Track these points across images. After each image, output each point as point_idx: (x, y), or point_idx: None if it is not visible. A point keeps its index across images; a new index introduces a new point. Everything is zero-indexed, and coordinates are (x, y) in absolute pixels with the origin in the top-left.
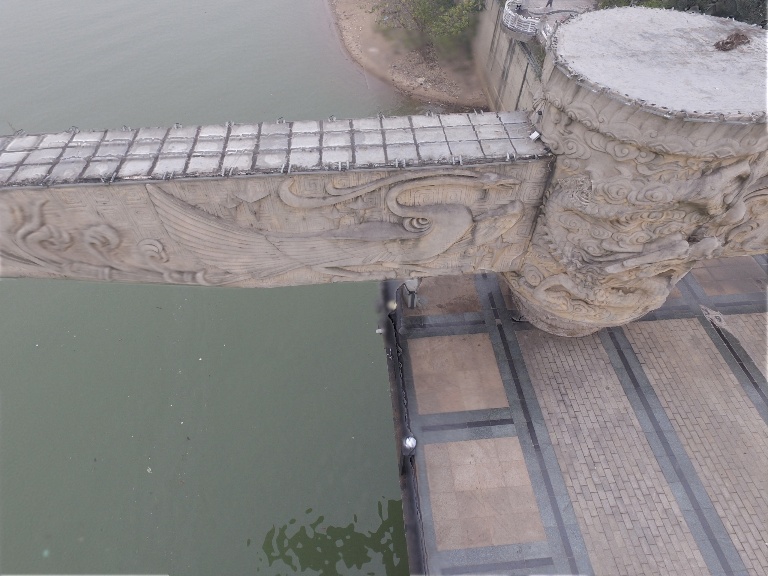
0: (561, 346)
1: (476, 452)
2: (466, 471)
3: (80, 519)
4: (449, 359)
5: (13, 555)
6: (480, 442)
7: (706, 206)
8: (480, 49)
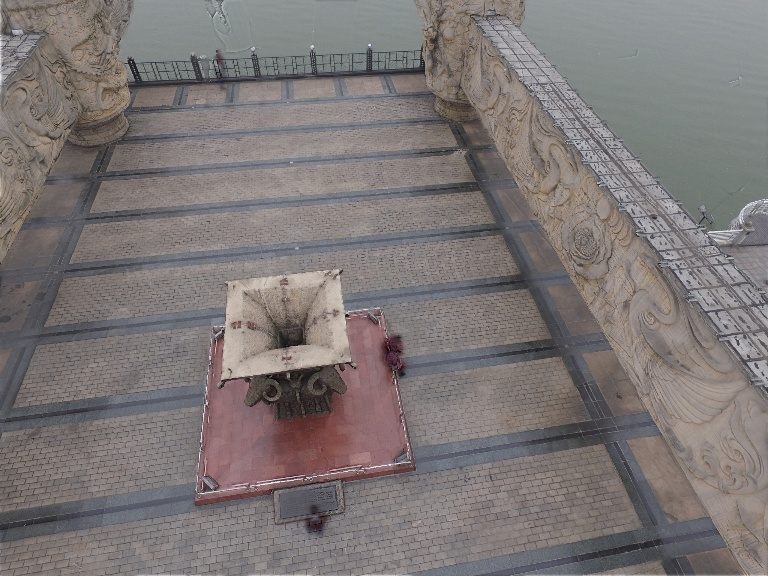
0: (430, 107)
1: (377, 85)
2: (370, 83)
3: (349, 27)
4: (416, 82)
5: (337, 8)
6: (381, 86)
7: (432, 7)
8: (757, 118)
